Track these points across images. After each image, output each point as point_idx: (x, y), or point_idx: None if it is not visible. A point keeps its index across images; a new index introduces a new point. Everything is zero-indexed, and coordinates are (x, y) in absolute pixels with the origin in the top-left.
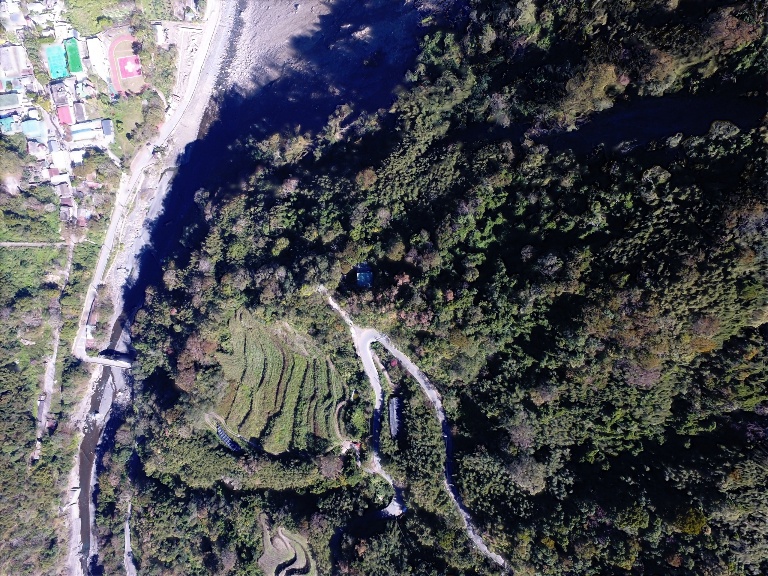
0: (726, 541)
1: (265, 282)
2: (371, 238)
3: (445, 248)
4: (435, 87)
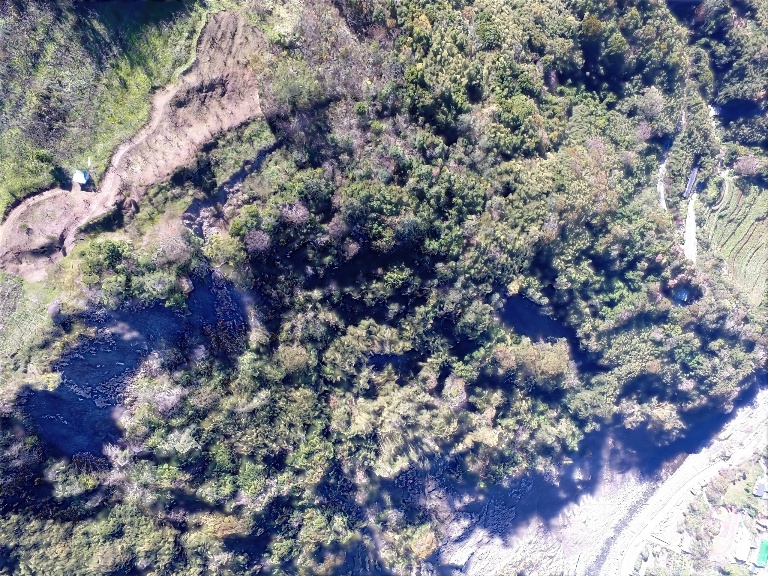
0: (582, 3)
1: (740, 323)
2: (670, 322)
3: (644, 293)
4: (591, 411)
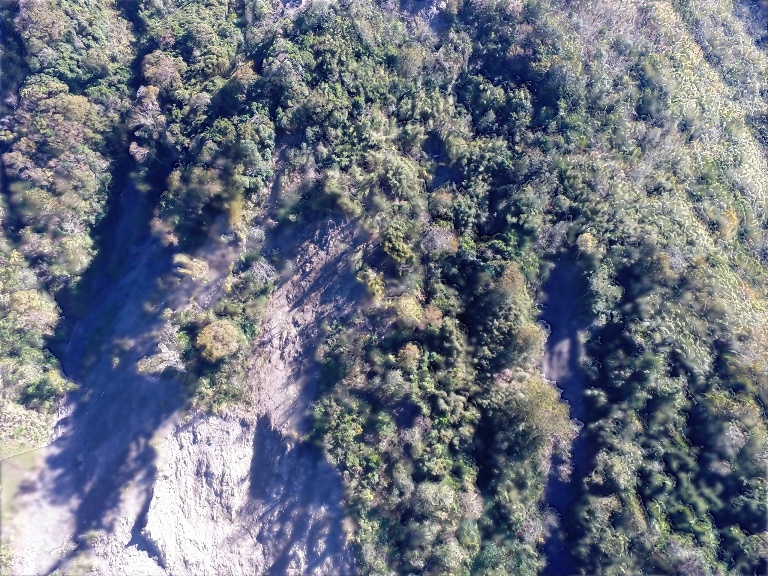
0: None
1: None
2: None
3: None
4: None
